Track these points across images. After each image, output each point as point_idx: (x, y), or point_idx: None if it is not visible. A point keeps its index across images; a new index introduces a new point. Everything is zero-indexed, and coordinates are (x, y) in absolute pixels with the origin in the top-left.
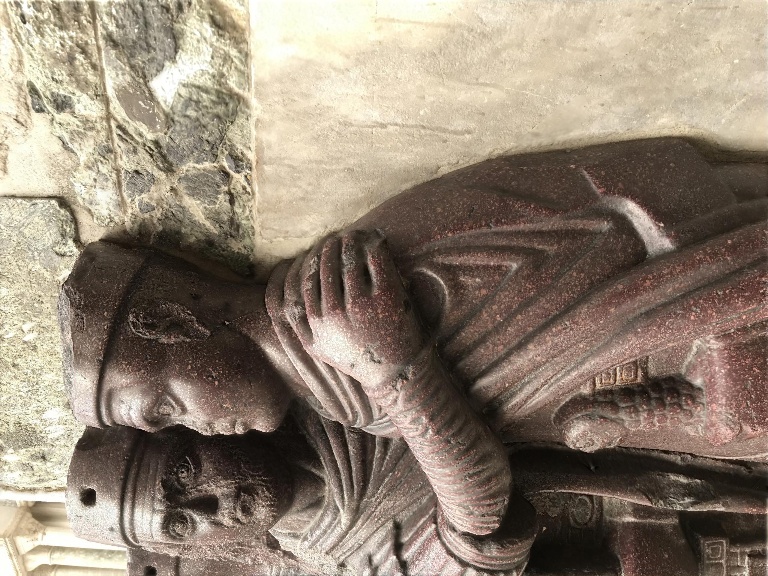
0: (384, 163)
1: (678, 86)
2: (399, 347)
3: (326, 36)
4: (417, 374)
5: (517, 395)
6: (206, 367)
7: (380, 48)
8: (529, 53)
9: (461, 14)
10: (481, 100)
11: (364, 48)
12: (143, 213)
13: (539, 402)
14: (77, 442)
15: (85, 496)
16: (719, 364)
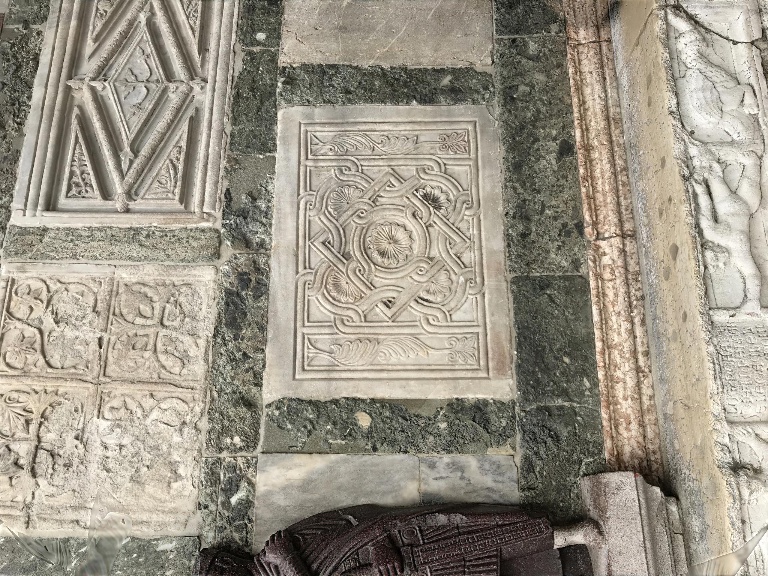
0: (290, 517)
1: (363, 490)
2: (287, 550)
3: (274, 484)
4: (291, 555)
5: (322, 569)
6: (235, 574)
7: (287, 486)
8: (324, 485)
9: (306, 477)
10: (314, 498)
11: (284, 486)
12: (220, 540)
13: (328, 571)
14: None
15: None
16: (373, 553)
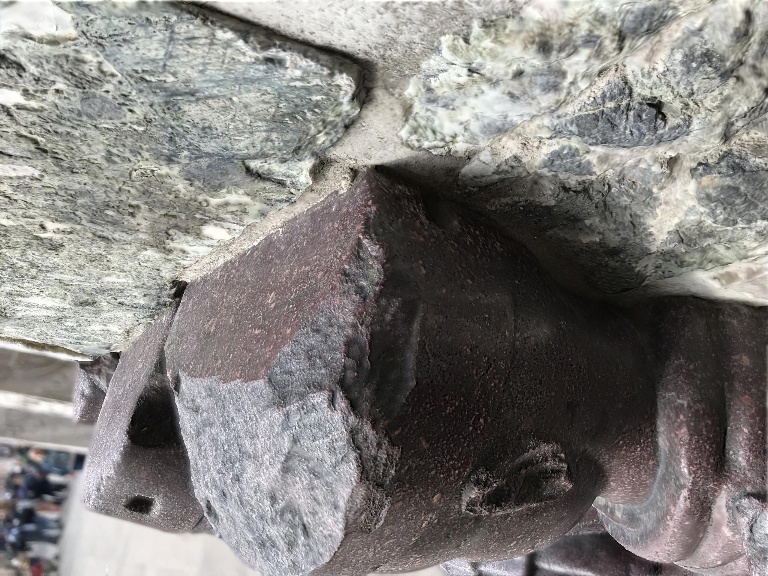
0: None
1: None
2: None
3: None
4: None
5: None
6: (536, 539)
7: None
8: None
9: None
10: None
11: None
12: None
13: None
14: (130, 424)
15: (132, 499)
16: None
